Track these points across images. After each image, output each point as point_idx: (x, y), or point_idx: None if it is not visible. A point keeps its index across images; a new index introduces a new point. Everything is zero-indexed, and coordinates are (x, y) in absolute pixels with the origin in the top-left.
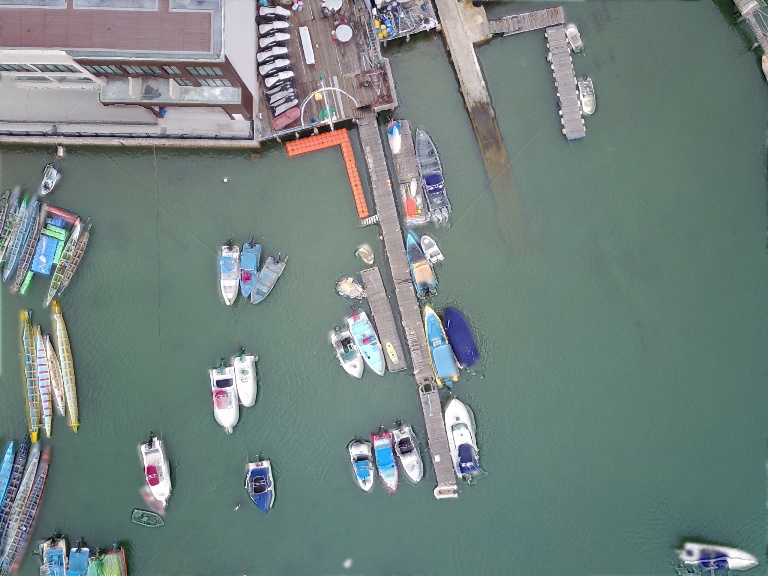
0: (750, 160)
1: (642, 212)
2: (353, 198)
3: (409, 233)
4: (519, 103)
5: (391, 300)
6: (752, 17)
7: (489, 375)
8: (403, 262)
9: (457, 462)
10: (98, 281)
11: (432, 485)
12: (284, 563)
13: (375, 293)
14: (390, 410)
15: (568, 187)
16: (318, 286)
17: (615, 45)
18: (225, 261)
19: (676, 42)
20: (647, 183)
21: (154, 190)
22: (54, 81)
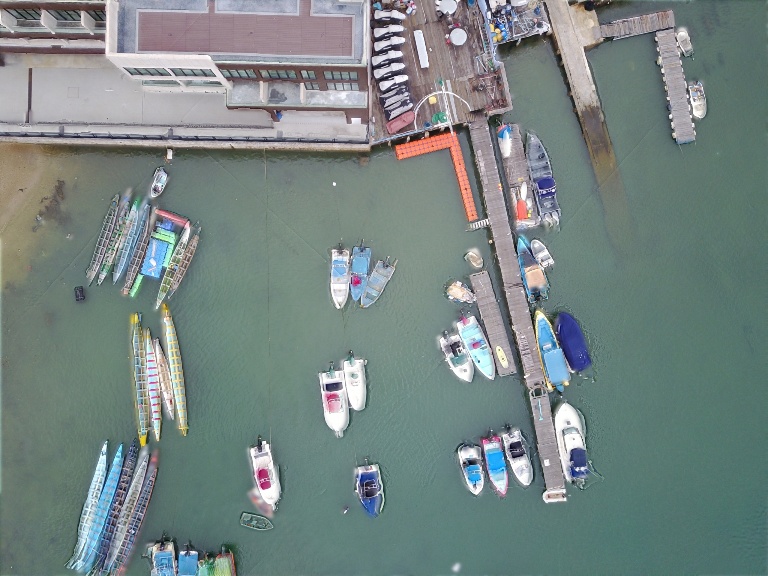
0: None
1: (750, 216)
2: (462, 202)
3: (519, 237)
4: (627, 107)
5: (500, 304)
6: None
7: (600, 379)
8: (514, 266)
9: (567, 466)
10: (206, 284)
11: (540, 489)
12: (391, 567)
13: (485, 297)
14: (498, 414)
15: (676, 191)
16: (426, 290)
17: (724, 49)
18: (337, 265)
19: None
20: (755, 187)
21: (263, 193)
22: (182, 85)
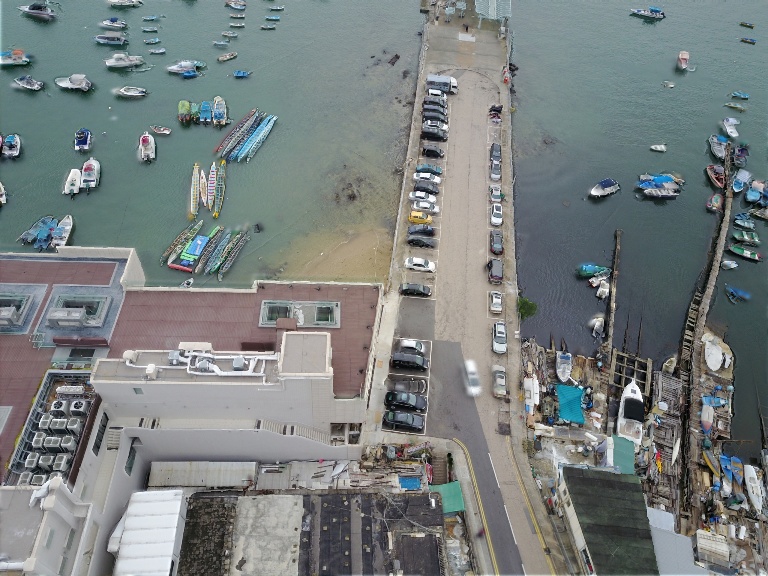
0: None
1: None
2: None
3: None
4: None
5: None
6: None
7: None
8: None
9: None
10: None
11: None
12: None
13: None
14: None
15: None
16: (4, 229)
17: None
18: (59, 232)
19: None
20: None
21: None
22: None
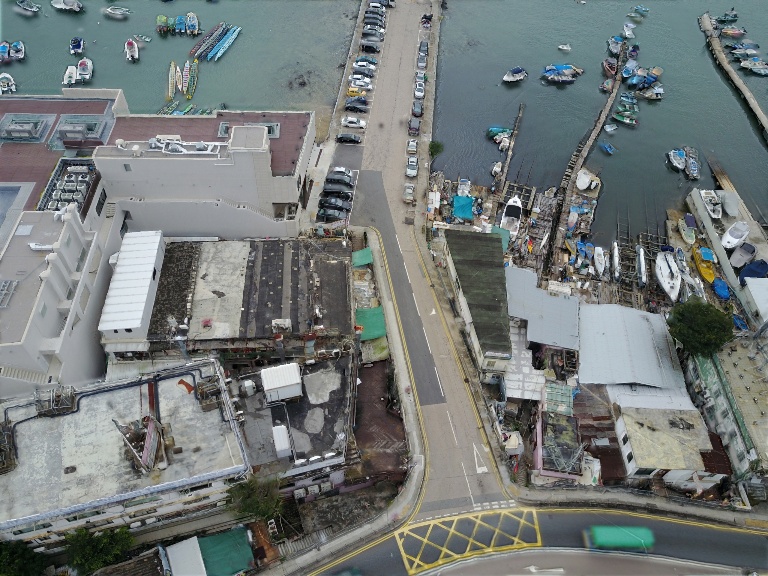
0: None
1: None
2: None
3: None
4: None
5: None
6: None
7: None
8: None
9: None
10: None
11: None
12: None
13: None
14: None
15: None
16: None
17: None
18: None
19: None
20: None
21: None
22: None
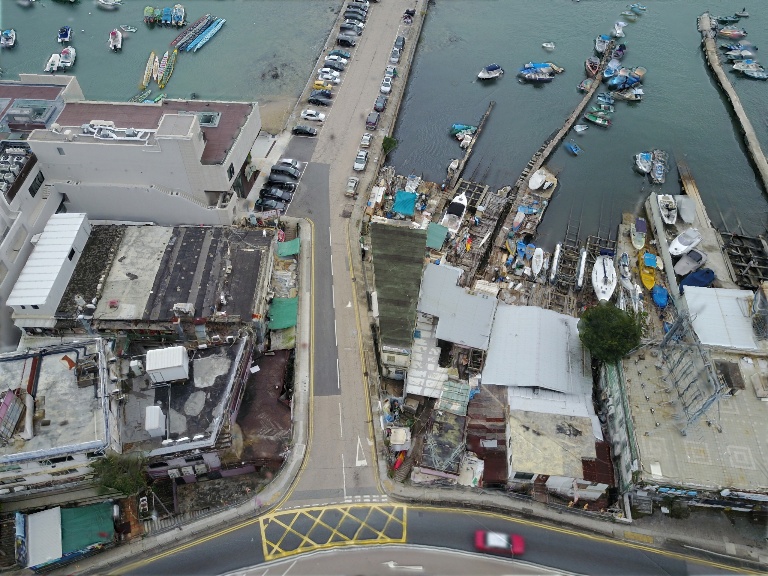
0: None
1: None
2: None
3: None
4: None
5: None
6: None
7: None
8: None
9: None
10: None
11: None
12: None
13: None
14: None
15: None
16: None
17: None
18: None
19: None
20: None
21: None
22: None
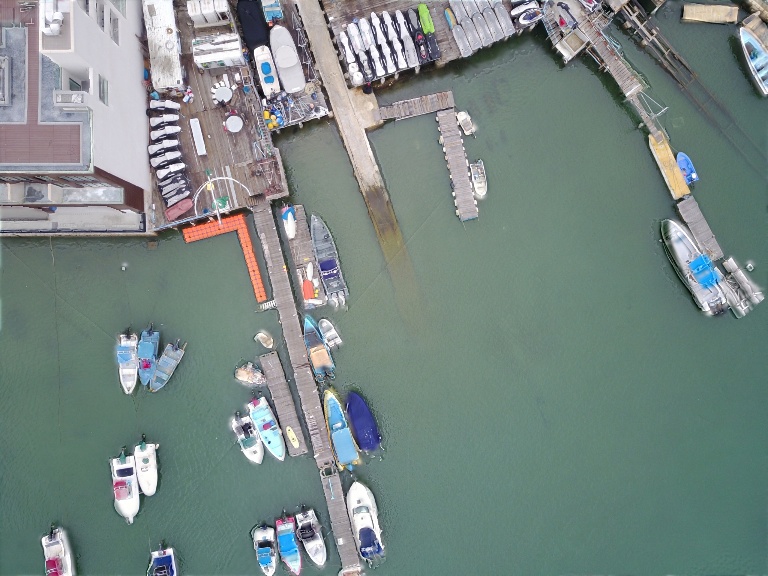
0: (642, 235)
1: (538, 289)
2: (251, 283)
3: (306, 317)
4: (414, 185)
5: (291, 384)
6: (636, 98)
7: (389, 457)
8: (300, 347)
9: None
10: None
11: (337, 568)
12: None
13: (274, 377)
14: (293, 493)
15: (464, 266)
16: (219, 371)
17: (506, 126)
18: (121, 351)
19: (566, 121)
20: (542, 260)
21: (52, 280)
22: None
